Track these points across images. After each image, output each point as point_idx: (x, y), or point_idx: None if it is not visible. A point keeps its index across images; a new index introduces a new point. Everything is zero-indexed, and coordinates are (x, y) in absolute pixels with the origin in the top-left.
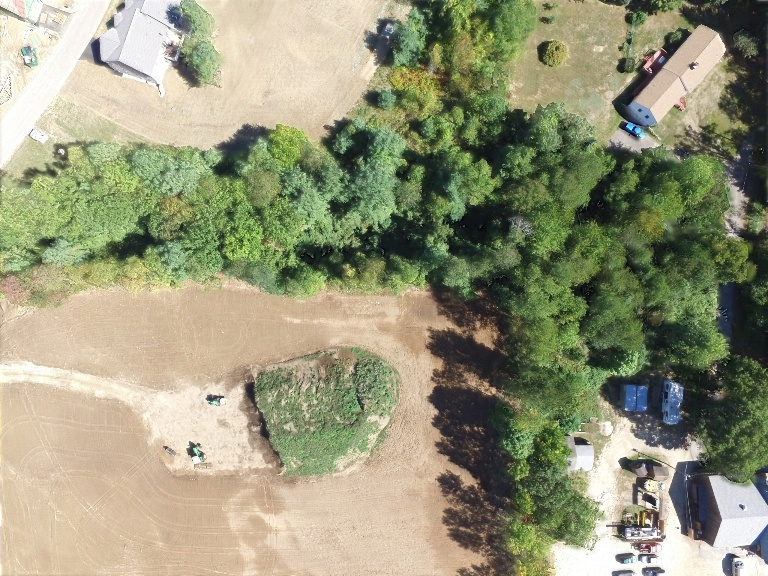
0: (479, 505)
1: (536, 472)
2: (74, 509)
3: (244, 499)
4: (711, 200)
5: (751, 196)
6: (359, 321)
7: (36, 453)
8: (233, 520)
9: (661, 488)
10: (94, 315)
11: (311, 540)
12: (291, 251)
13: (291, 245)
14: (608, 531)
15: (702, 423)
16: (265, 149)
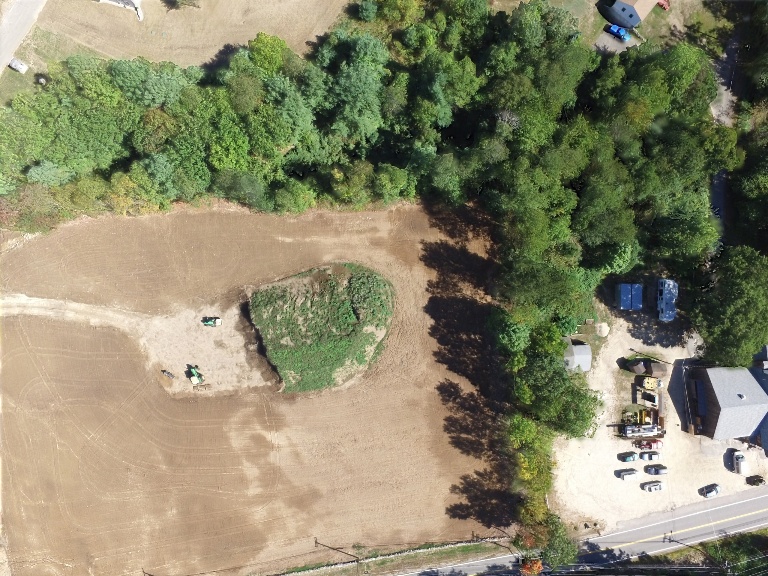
0: (479, 411)
1: (533, 362)
2: (76, 438)
3: (245, 418)
4: (698, 87)
5: (739, 95)
6: (351, 237)
7: (34, 384)
8: (235, 439)
9: (660, 385)
10: (85, 244)
11: (314, 455)
12: (279, 165)
13: (278, 159)
14: (609, 431)
15: (697, 308)
16: (247, 57)
